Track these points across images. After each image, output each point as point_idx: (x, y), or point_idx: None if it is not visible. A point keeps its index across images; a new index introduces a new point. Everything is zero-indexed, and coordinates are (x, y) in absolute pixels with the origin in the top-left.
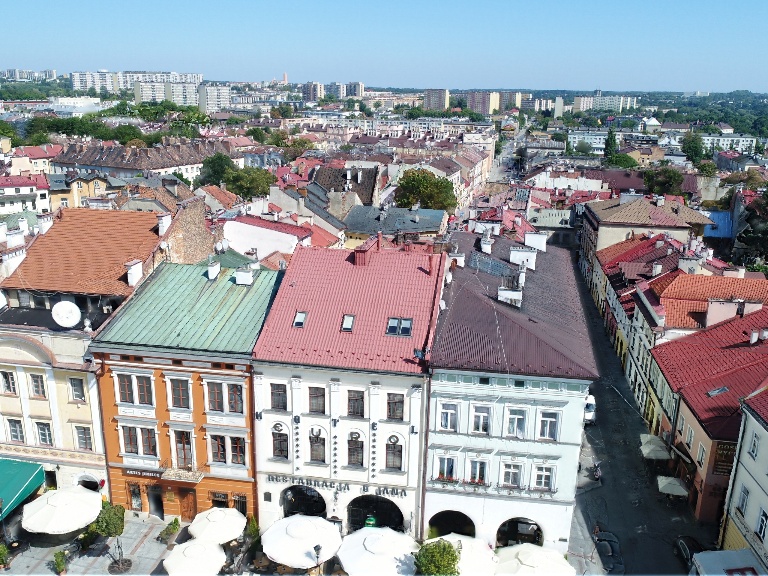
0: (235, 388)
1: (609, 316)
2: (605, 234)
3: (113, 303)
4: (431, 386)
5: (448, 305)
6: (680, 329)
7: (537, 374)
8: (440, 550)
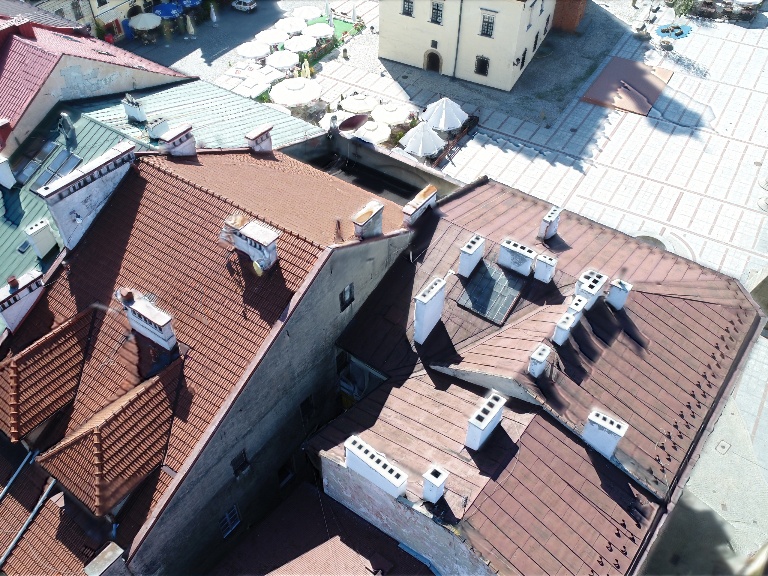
0: None
1: None
2: None
3: None
4: None
5: None
6: None
7: None
8: None
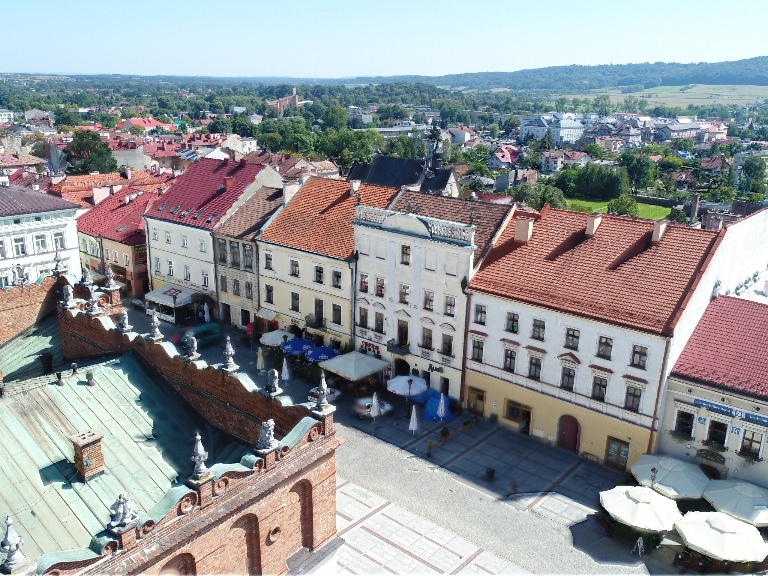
0: None
1: None
2: None
3: None
4: None
5: None
6: (81, 209)
7: (48, 210)
8: None
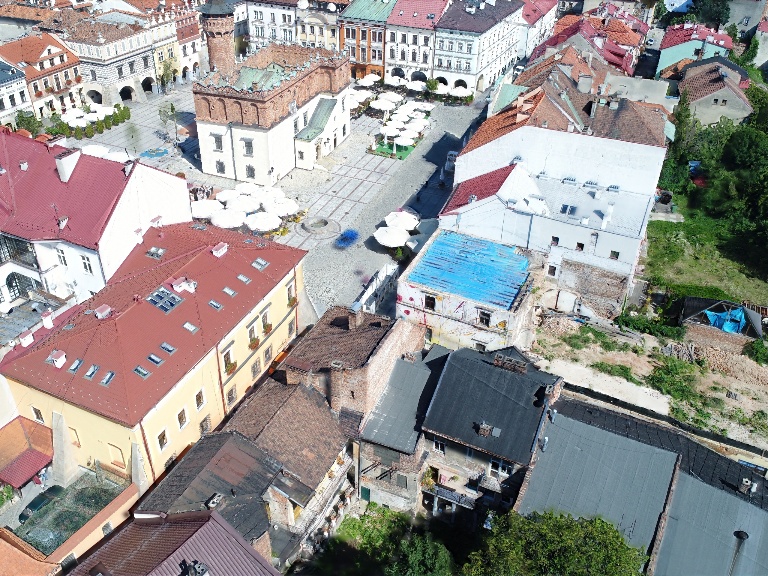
0: (380, 34)
1: None
2: (588, 3)
3: (344, 7)
4: (437, 34)
5: (449, 11)
6: None
7: (465, 30)
8: (433, 81)
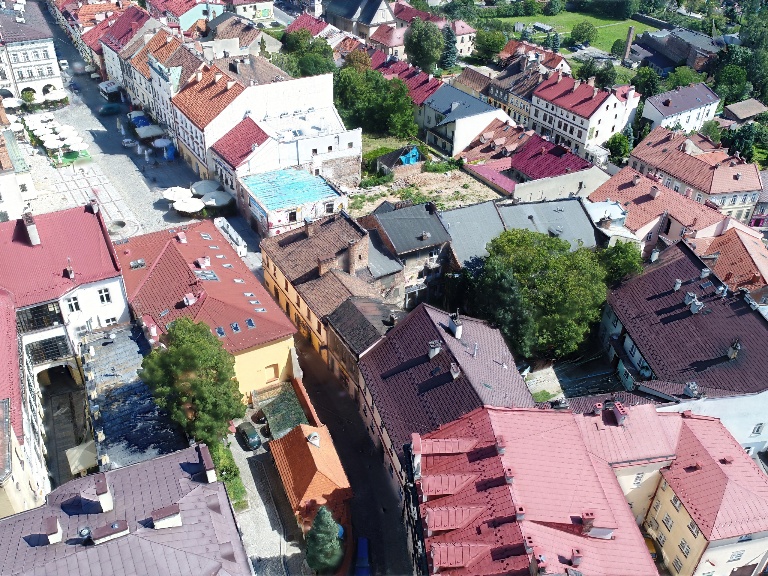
0: None
1: (69, 32)
2: None
3: None
4: (7, 49)
5: (2, 26)
6: (88, 27)
7: (37, 39)
8: (28, 93)
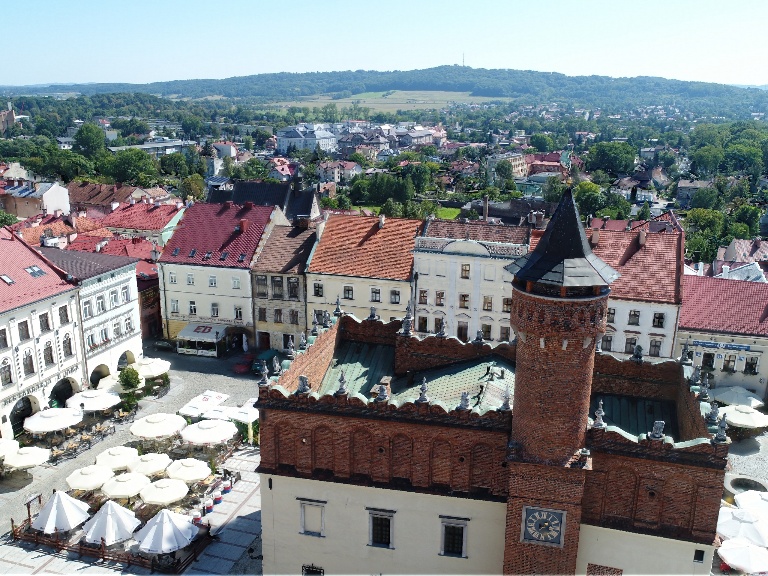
0: None
1: None
2: None
3: None
4: None
5: None
6: None
7: (121, 266)
8: None
